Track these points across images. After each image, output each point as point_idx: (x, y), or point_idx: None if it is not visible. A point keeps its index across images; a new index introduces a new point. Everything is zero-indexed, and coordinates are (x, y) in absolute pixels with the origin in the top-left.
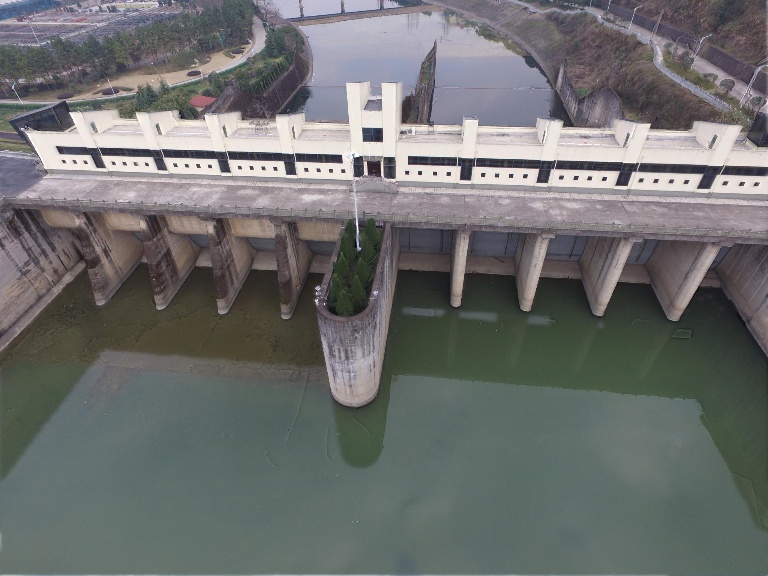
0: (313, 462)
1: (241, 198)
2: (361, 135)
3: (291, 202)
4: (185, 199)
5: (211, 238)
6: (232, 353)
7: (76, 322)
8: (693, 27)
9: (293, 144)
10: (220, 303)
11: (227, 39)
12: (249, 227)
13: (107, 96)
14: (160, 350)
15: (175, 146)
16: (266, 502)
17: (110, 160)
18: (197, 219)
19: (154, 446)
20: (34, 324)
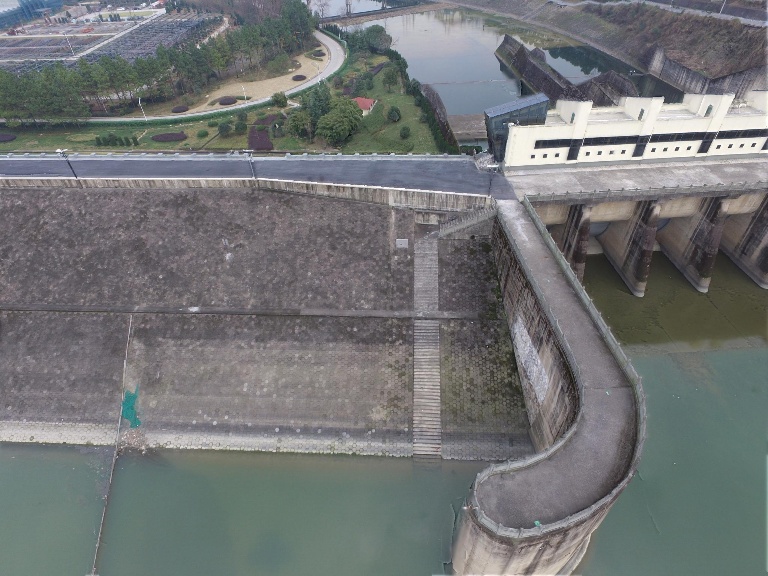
0: None
1: (740, 175)
2: None
3: None
4: (690, 181)
5: (724, 216)
6: (765, 324)
7: None
8: None
9: None
10: (707, 281)
11: (303, 42)
12: (730, 204)
13: (230, 106)
14: (696, 332)
15: (668, 130)
16: None
17: (586, 151)
18: (682, 201)
19: None
20: None
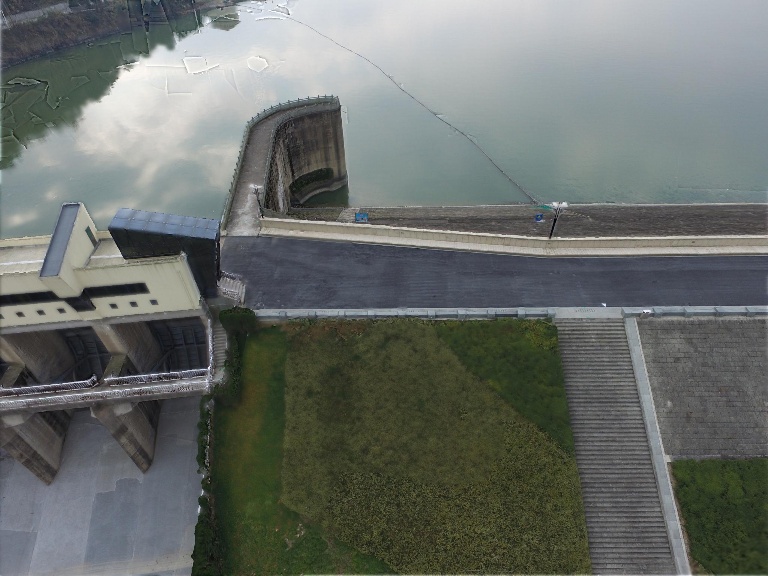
0: None
1: None
2: None
3: None
4: None
5: None
6: None
7: None
8: None
9: None
10: None
11: None
12: None
13: None
14: None
15: None
16: None
17: None
18: None
19: None
20: None
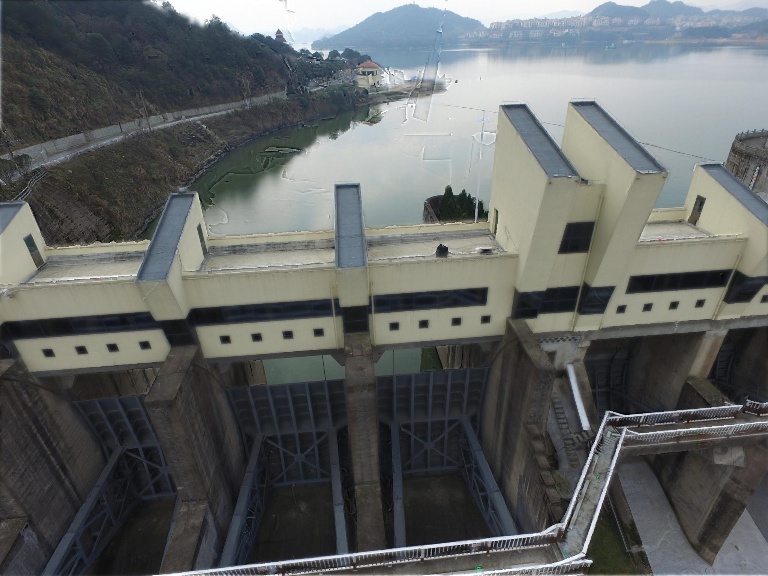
0: None
1: None
2: None
3: None
4: None
5: None
6: None
7: None
8: None
9: None
10: None
11: None
12: None
13: None
14: None
15: None
16: None
17: None
18: None
19: None
20: None
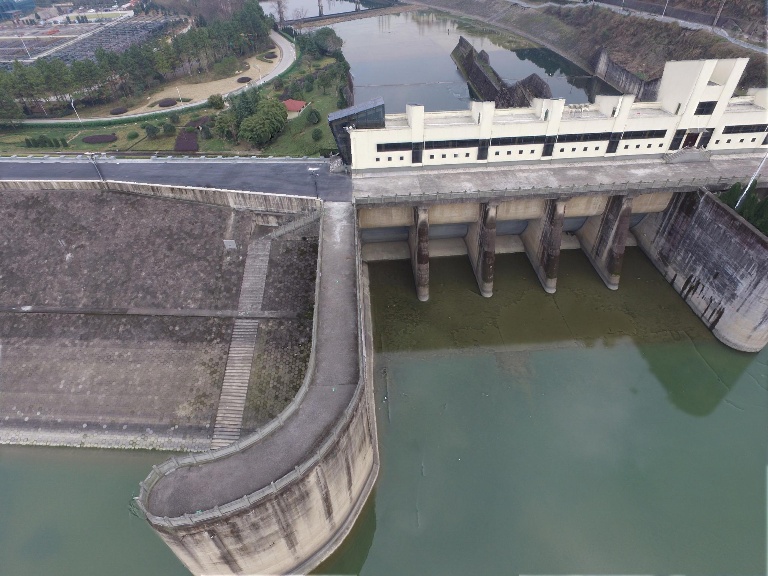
0: (767, 401)
1: (579, 178)
2: (695, 109)
3: (629, 177)
4: (527, 184)
5: (560, 218)
6: (599, 325)
7: (418, 319)
8: (737, 12)
9: (626, 123)
10: (553, 282)
11: (256, 44)
12: (575, 206)
13: (168, 108)
14: (529, 332)
15: (507, 134)
16: (762, 440)
17: (429, 154)
18: (526, 203)
19: (615, 413)
20: (376, 327)
